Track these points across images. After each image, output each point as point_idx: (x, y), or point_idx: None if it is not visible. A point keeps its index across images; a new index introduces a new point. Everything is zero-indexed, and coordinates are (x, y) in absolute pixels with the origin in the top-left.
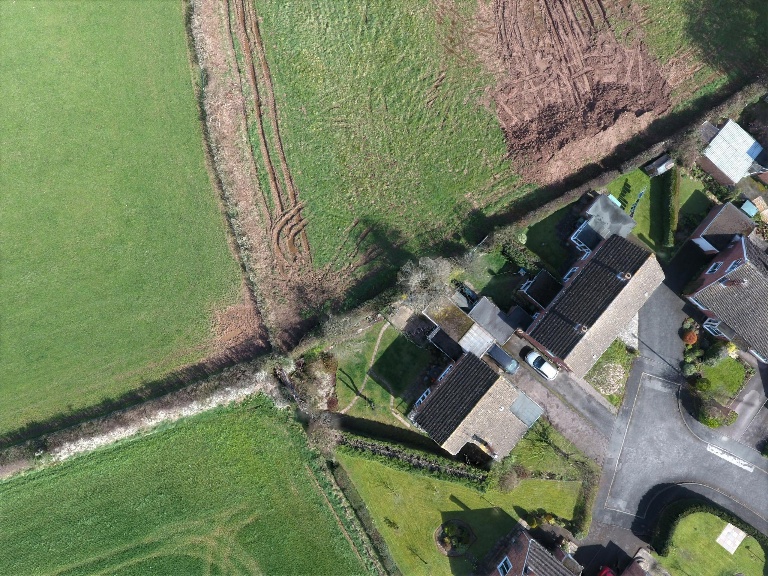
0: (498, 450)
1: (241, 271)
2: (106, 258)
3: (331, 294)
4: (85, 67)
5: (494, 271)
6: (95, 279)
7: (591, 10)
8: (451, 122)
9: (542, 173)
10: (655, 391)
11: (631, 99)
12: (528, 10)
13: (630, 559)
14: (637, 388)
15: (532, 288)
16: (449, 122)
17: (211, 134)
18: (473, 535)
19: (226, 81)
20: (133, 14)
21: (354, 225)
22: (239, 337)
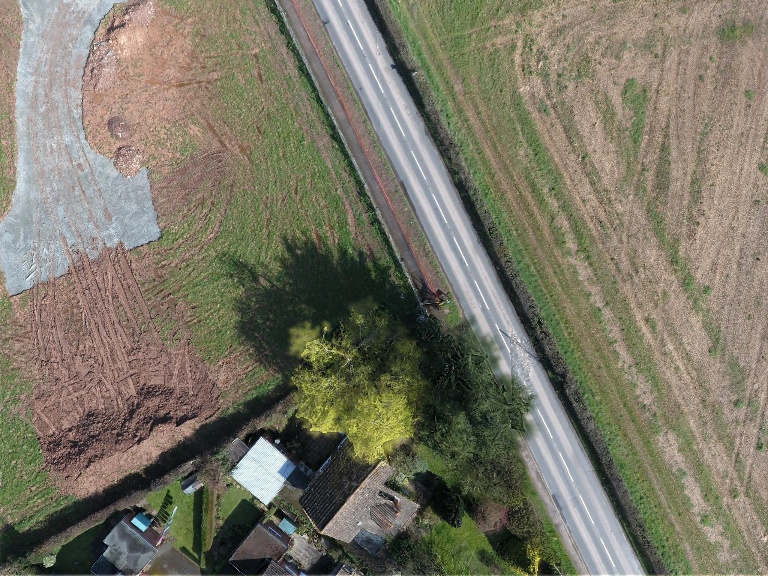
0: None
1: None
2: None
3: None
4: None
5: None
6: None
7: (135, 311)
8: None
9: (74, 489)
10: None
11: (175, 405)
12: (67, 313)
13: None
14: None
15: None
16: None
17: None
18: None
19: None
20: None
21: None
22: None
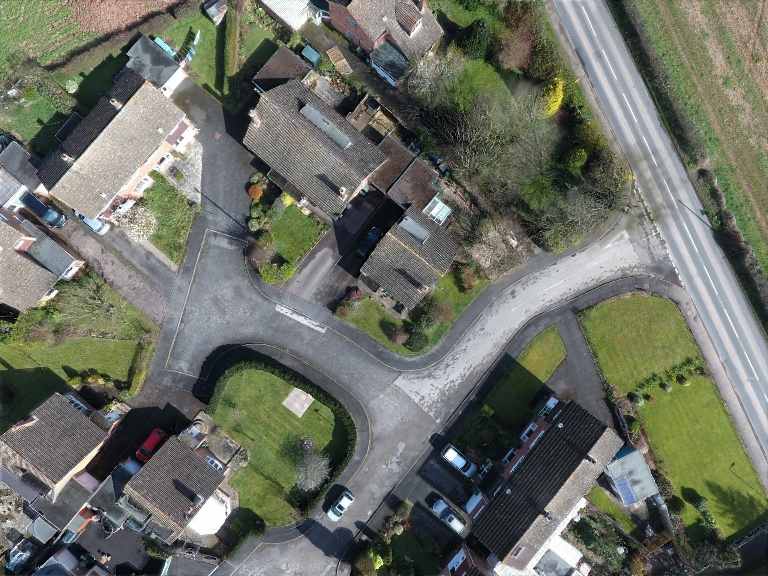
0: (17, 299)
1: None
2: None
3: None
4: None
5: (44, 121)
6: None
7: None
8: None
9: (96, 19)
10: (220, 248)
11: None
12: None
13: (189, 422)
14: (200, 245)
15: (62, 132)
16: None
17: None
18: (18, 396)
19: None
20: None
21: None
22: None
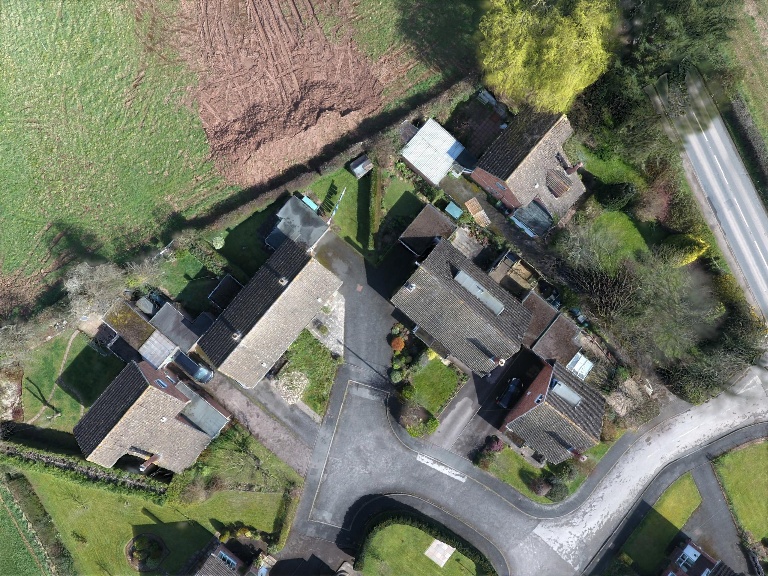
0: (174, 462)
1: None
2: None
3: (20, 301)
4: None
5: (190, 276)
6: None
7: (299, 6)
8: (151, 122)
9: (242, 175)
10: (362, 399)
11: (339, 98)
12: (233, 7)
13: (333, 573)
14: (343, 396)
15: (216, 294)
16: (148, 122)
17: None
18: (166, 549)
19: None
20: None
21: (47, 229)
22: None
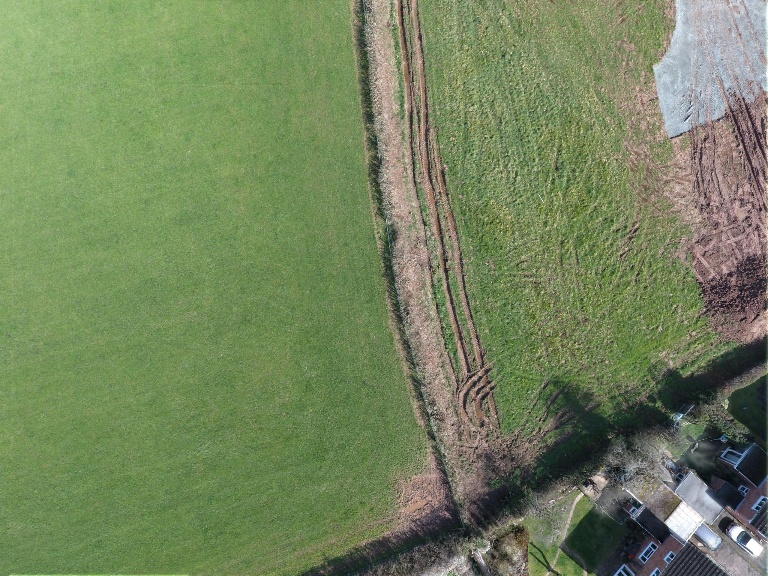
0: None
1: (427, 438)
2: (286, 425)
3: (520, 461)
4: (263, 220)
5: (693, 438)
6: (275, 448)
7: None
8: (645, 276)
9: (744, 333)
10: None
11: None
12: (726, 156)
13: None
14: None
15: (743, 464)
16: (643, 276)
17: (401, 296)
18: None
19: (411, 235)
20: (313, 163)
21: (543, 387)
22: (425, 509)
